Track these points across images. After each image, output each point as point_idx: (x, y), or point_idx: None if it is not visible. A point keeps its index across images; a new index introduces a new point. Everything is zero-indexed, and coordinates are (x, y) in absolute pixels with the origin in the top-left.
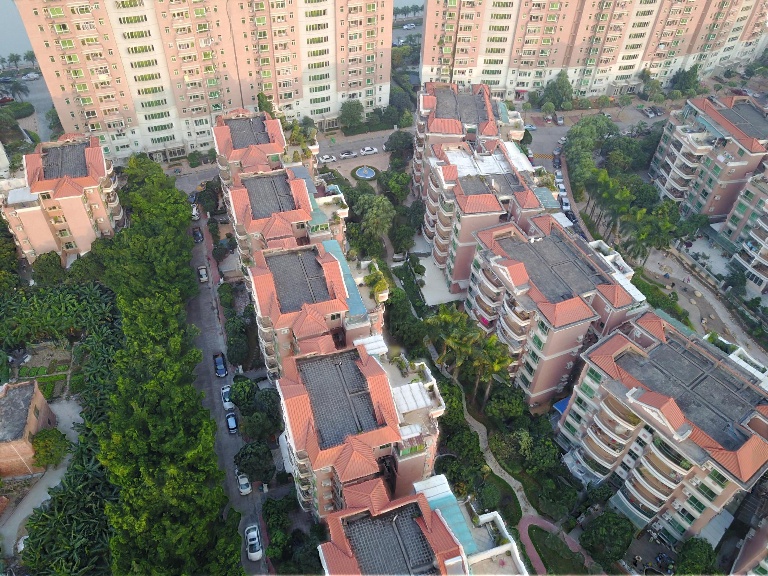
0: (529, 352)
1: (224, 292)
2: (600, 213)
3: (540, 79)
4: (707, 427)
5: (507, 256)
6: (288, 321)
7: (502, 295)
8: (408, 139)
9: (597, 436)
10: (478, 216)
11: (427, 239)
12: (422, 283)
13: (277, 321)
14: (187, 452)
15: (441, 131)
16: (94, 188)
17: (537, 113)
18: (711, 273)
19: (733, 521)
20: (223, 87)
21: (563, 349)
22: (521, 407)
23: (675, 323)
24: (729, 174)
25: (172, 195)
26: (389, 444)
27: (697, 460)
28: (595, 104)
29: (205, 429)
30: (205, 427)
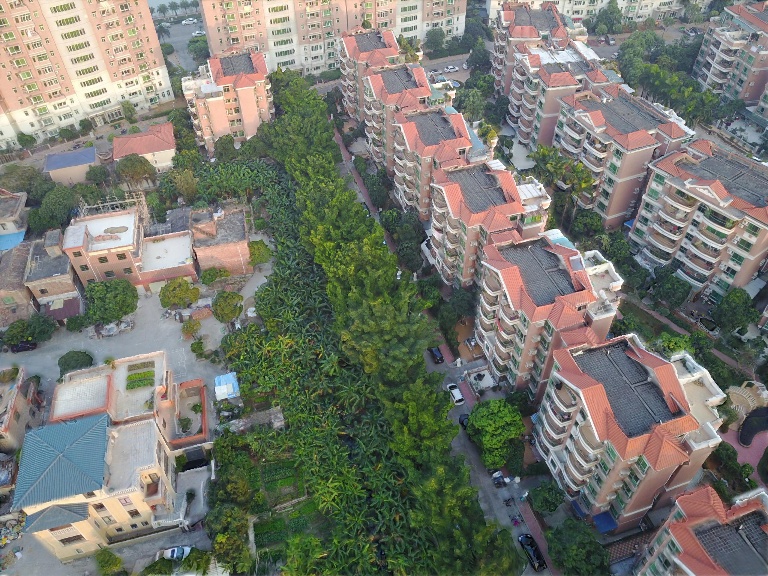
0: (606, 180)
1: (359, 162)
2: (652, 101)
3: (593, 7)
4: (744, 200)
5: (587, 109)
6: (431, 151)
7: (583, 142)
8: (487, 54)
9: (661, 227)
10: (559, 89)
11: (512, 124)
12: (511, 155)
13: (423, 151)
14: (369, 236)
15: (521, 36)
16: (261, 82)
17: (591, 37)
18: (747, 142)
19: (766, 285)
20: (334, 18)
21: (632, 174)
22: (600, 223)
23: (719, 146)
24: (761, 61)
25: (311, 93)
26: (516, 217)
27: (737, 217)
28: (642, 27)
29: (376, 226)
30: (376, 225)
